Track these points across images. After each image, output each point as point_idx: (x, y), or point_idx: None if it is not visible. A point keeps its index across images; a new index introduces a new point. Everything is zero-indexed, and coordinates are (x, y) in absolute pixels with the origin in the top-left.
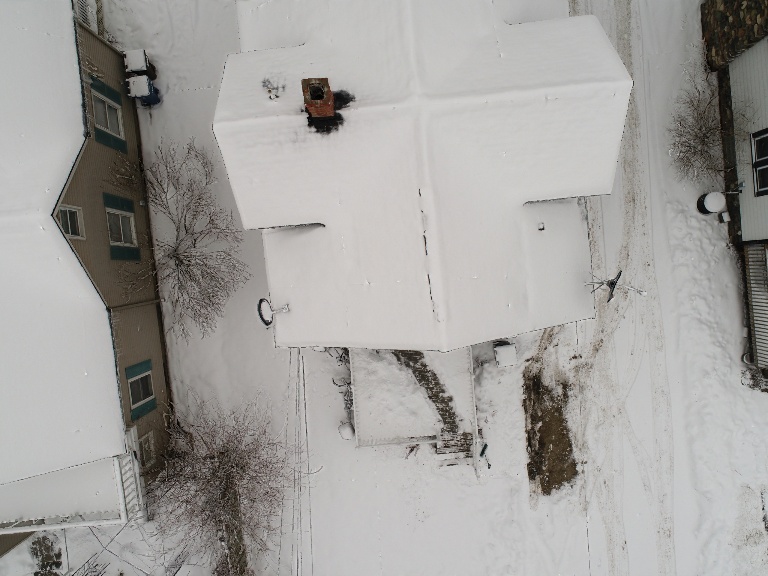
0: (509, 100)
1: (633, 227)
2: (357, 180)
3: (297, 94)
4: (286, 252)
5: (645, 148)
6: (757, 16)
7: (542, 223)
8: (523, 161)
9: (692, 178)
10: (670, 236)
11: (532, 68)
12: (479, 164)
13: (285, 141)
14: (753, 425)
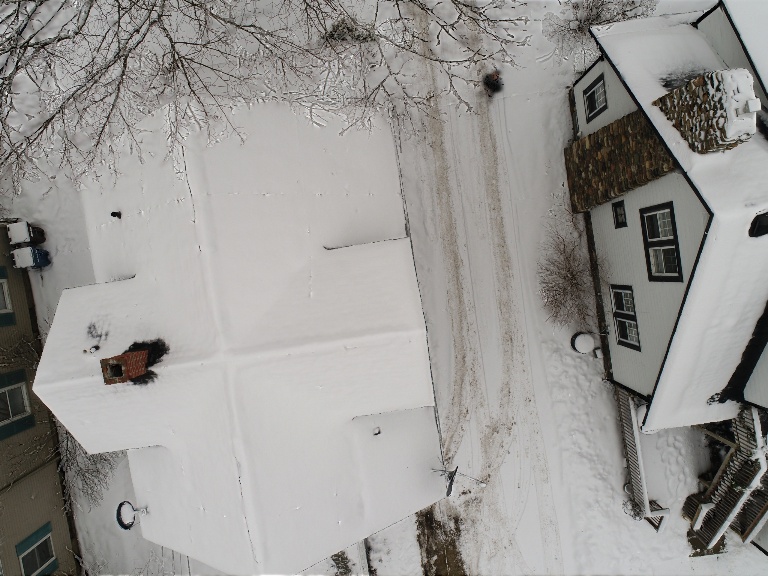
0: (310, 352)
1: (512, 365)
2: (184, 416)
3: (116, 345)
4: (141, 458)
5: (519, 289)
6: (599, 183)
7: (377, 428)
8: (340, 391)
9: (561, 322)
10: (547, 374)
11: (336, 312)
12: (297, 397)
13: (106, 393)
14: (639, 551)
